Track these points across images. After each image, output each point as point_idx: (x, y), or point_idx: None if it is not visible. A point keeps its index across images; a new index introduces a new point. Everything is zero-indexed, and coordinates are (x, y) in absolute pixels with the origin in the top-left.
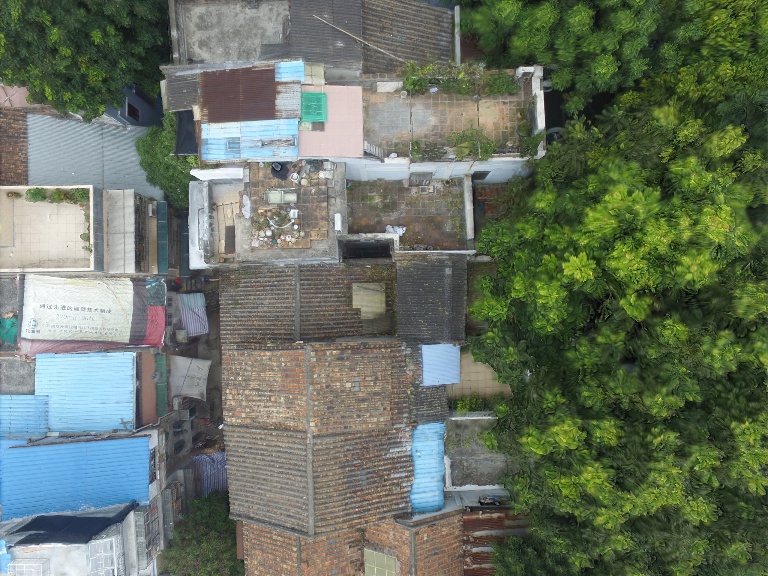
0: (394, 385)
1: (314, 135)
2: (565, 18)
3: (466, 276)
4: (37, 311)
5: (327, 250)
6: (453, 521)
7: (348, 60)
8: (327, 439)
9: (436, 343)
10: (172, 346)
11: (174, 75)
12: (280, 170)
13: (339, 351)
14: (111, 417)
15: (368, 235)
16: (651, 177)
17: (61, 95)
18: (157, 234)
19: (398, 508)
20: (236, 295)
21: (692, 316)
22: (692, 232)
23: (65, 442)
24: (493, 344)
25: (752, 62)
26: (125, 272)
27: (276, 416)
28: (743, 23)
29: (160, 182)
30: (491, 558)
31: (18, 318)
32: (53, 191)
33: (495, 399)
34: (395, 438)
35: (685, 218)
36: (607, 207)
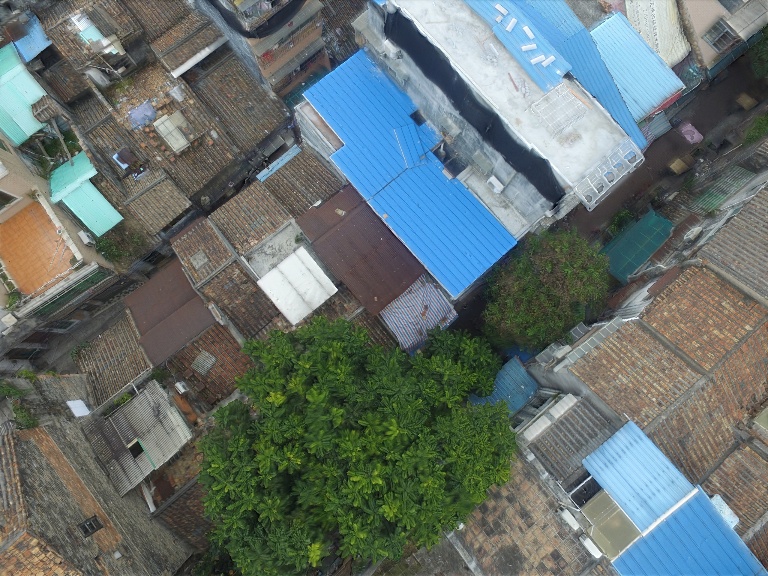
0: None
1: None
2: None
3: None
4: None
5: None
6: None
7: None
8: None
9: None
10: None
11: None
12: None
13: None
14: None
15: None
16: None
17: None
18: (737, 47)
19: None
20: None
21: None
22: None
23: None
24: None
25: None
26: (739, 33)
27: None
28: None
29: None
30: None
31: None
32: None
33: None
34: None
35: None
36: None
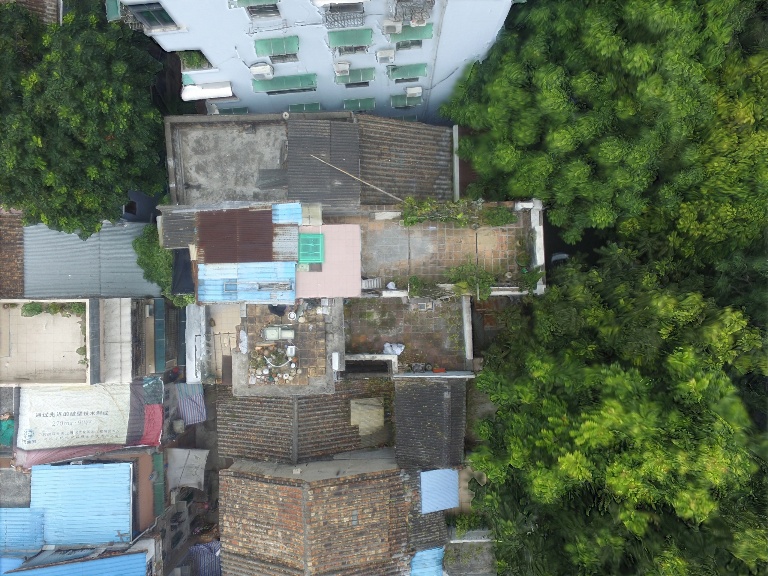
0: (392, 514)
1: (311, 276)
2: (564, 170)
3: (465, 398)
4: (33, 421)
5: (325, 386)
6: None
7: (346, 198)
8: None
9: (435, 468)
10: (169, 438)
11: (170, 212)
12: (277, 306)
13: (337, 486)
14: (107, 529)
15: (366, 356)
16: (651, 356)
17: (57, 220)
18: (154, 332)
19: None
20: (233, 407)
21: (693, 538)
22: (693, 470)
23: (61, 563)
24: (492, 508)
25: (752, 204)
26: (122, 382)
27: (273, 550)
28: (743, 169)
29: (157, 280)
30: None
31: (14, 427)
32: (49, 305)
33: None
34: (393, 568)
35: (686, 441)
36: (607, 387)
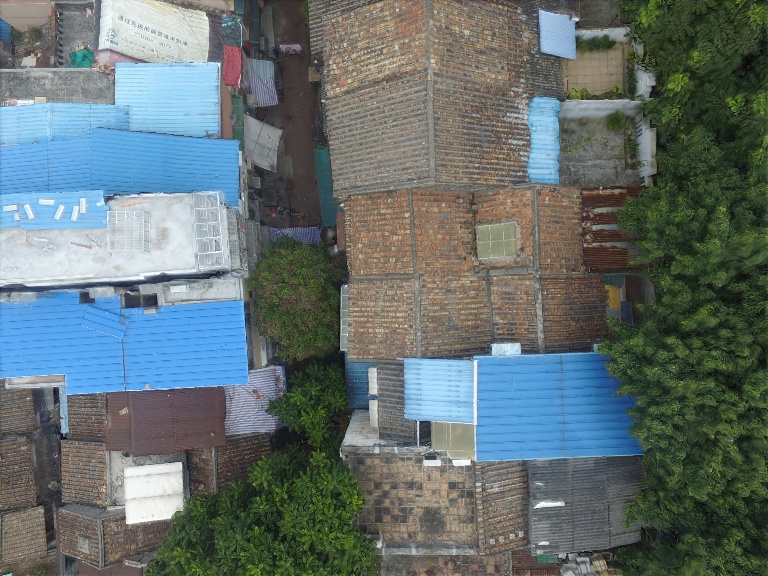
0: (511, 47)
1: None
2: None
3: None
4: (115, 22)
5: None
6: (572, 195)
7: None
8: (447, 81)
9: (552, 12)
10: (244, 106)
11: None
12: None
13: None
14: (195, 129)
15: None
16: None
17: None
18: None
19: (516, 176)
20: None
21: None
22: None
23: None
24: None
25: None
26: None
27: (389, 68)
28: None
29: None
30: (612, 236)
31: (95, 32)
32: None
33: (606, 95)
34: (512, 103)
35: None
36: None
